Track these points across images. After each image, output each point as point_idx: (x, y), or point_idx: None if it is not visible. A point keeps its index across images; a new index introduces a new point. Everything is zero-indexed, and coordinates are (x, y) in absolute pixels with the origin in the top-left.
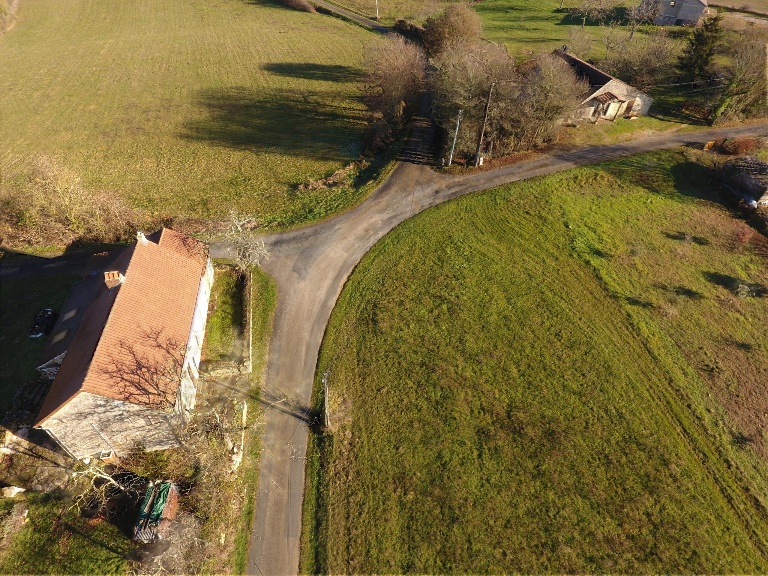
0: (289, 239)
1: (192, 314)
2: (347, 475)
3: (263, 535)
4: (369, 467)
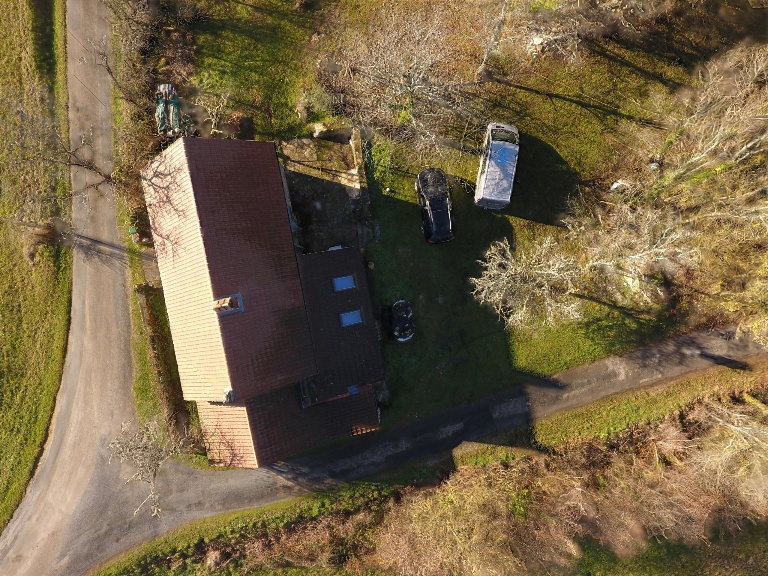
0: (138, 524)
1: (167, 308)
2: (25, 180)
3: (102, 127)
4: (3, 188)
